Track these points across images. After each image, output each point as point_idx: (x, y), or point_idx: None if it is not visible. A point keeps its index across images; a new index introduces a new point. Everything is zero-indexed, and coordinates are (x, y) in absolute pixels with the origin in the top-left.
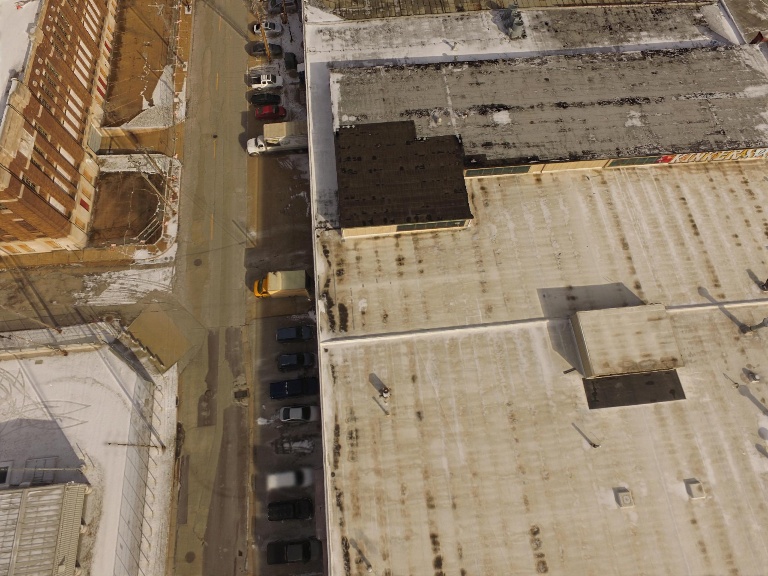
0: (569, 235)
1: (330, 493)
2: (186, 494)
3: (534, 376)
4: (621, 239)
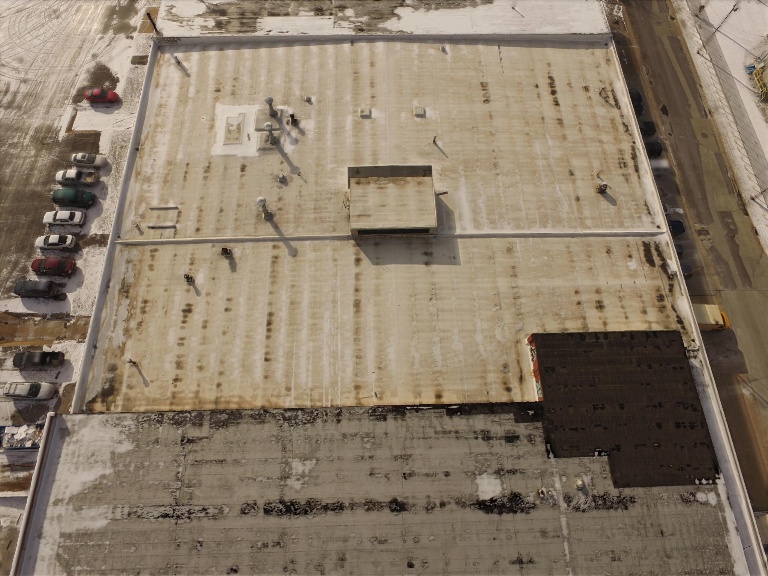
0: (416, 320)
1: (634, 132)
2: (722, 170)
3: (474, 192)
4: (359, 312)
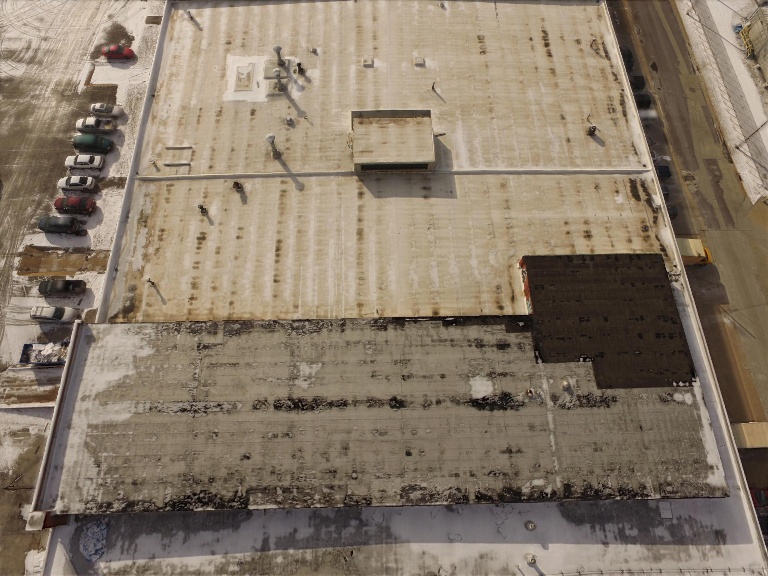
0: (415, 247)
1: (623, 81)
2: (708, 121)
3: (470, 134)
4: (362, 239)
